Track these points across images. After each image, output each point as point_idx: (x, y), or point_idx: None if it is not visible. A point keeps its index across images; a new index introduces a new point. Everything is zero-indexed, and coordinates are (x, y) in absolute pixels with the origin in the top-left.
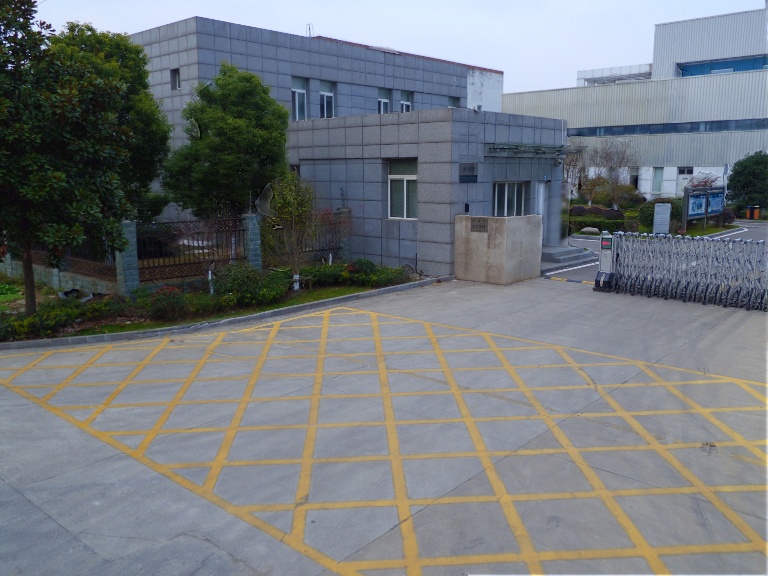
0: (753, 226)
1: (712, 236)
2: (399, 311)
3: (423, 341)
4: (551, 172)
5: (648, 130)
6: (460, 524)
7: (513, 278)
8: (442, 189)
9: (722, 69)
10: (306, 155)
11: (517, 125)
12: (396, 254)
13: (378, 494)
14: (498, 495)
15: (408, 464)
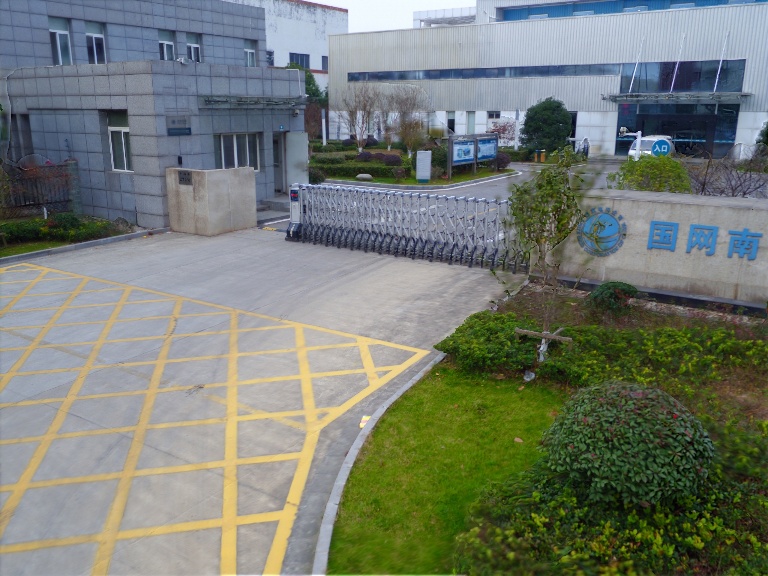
0: (532, 170)
1: (478, 181)
2: (75, 266)
3: (61, 297)
4: (289, 122)
5: (461, 74)
6: None
7: (221, 229)
8: (150, 142)
9: (538, 14)
10: (32, 104)
11: (240, 77)
12: (120, 207)
13: None
14: None
15: None
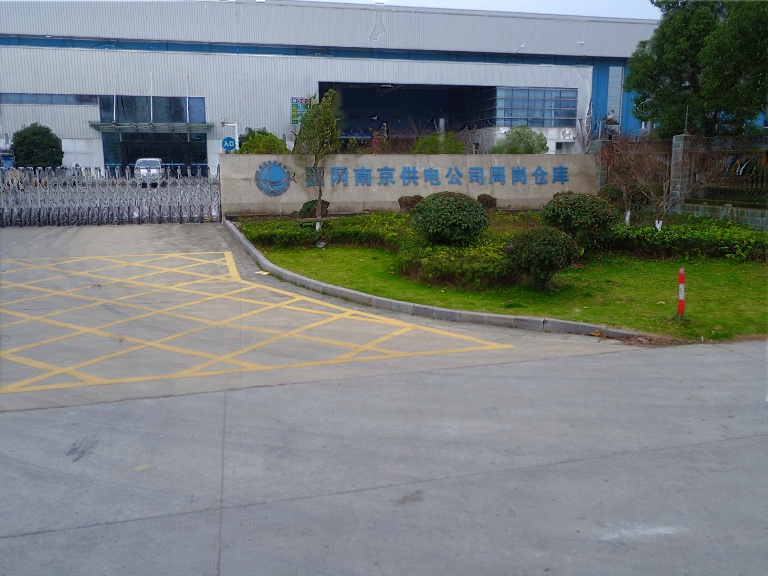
0: None
1: None
2: None
3: None
4: None
5: None
6: None
7: None
8: None
9: None
10: None
11: None
12: None
13: None
14: None
15: None
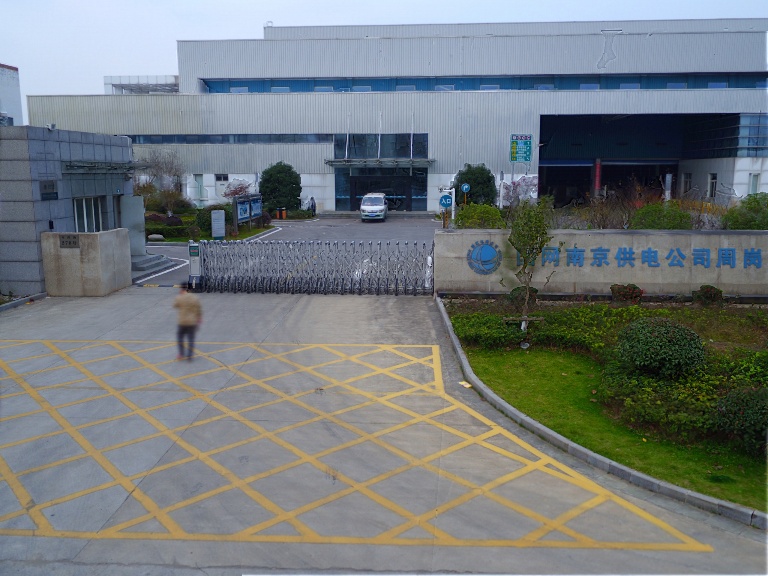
0: (284, 225)
1: (258, 236)
2: (6, 334)
3: (53, 358)
4: (123, 186)
5: (185, 140)
6: (179, 480)
7: (110, 289)
8: (23, 207)
9: (239, 87)
10: None
11: (89, 143)
12: None
13: (98, 481)
14: (196, 455)
15: (109, 454)
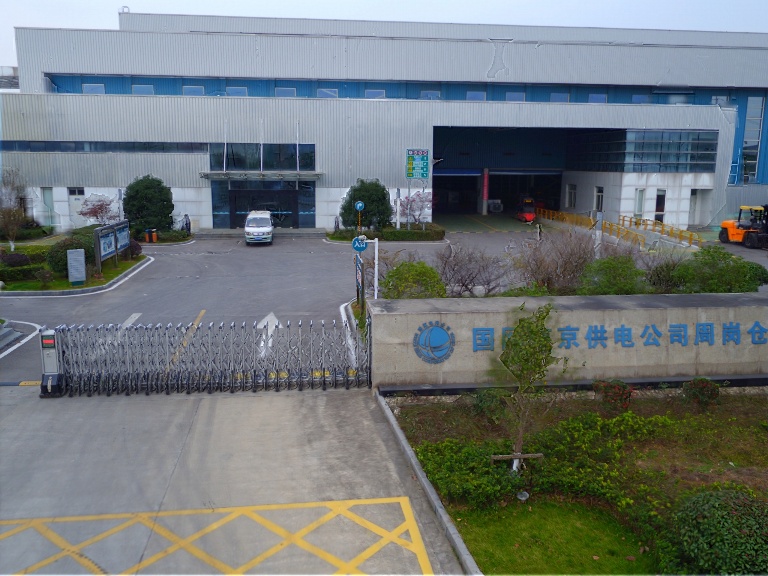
0: (156, 252)
1: (126, 274)
2: None
3: None
4: None
5: (28, 147)
6: None
7: None
8: None
9: (93, 84)
10: None
11: None
12: None
13: None
14: None
15: None
